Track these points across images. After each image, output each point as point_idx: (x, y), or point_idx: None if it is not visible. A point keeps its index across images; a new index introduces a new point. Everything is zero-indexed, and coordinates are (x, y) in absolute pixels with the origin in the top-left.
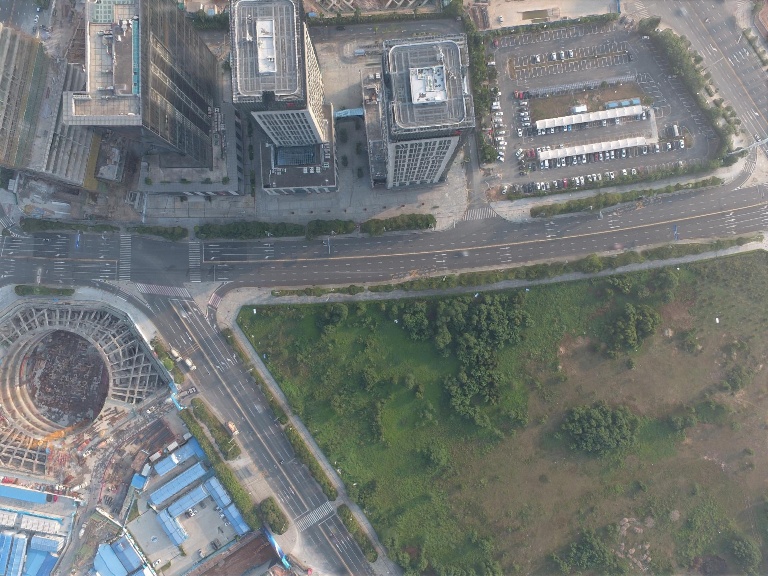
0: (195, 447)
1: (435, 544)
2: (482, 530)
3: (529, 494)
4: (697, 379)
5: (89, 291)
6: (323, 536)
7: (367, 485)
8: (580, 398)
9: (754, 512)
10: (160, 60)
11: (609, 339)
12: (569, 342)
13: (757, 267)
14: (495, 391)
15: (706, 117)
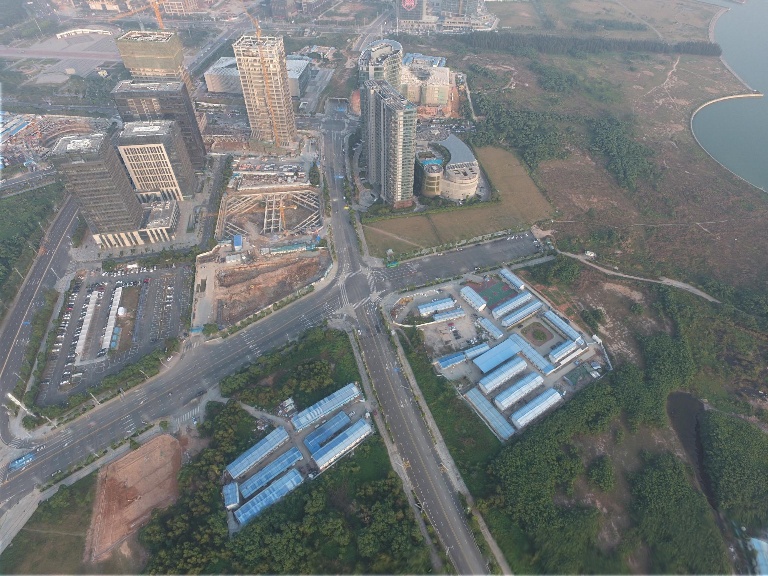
0: None
1: None
2: None
3: None
4: None
5: None
6: None
7: None
8: None
9: None
10: (154, 108)
11: None
12: None
13: None
14: None
15: None
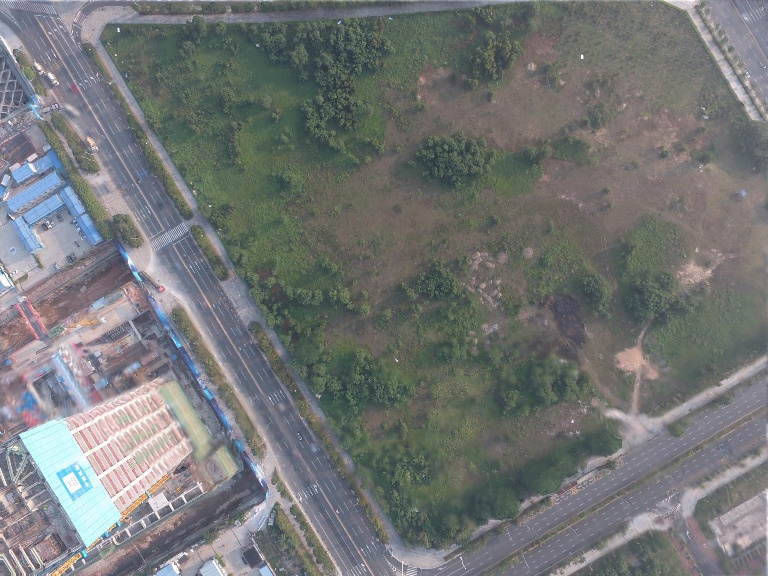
0: (53, 158)
1: (286, 269)
2: (334, 257)
3: (382, 224)
4: (558, 115)
5: None
6: (177, 256)
7: (222, 207)
8: (438, 129)
9: (610, 254)
10: None
11: (470, 70)
12: (430, 73)
13: (627, 4)
14: (351, 116)
15: None
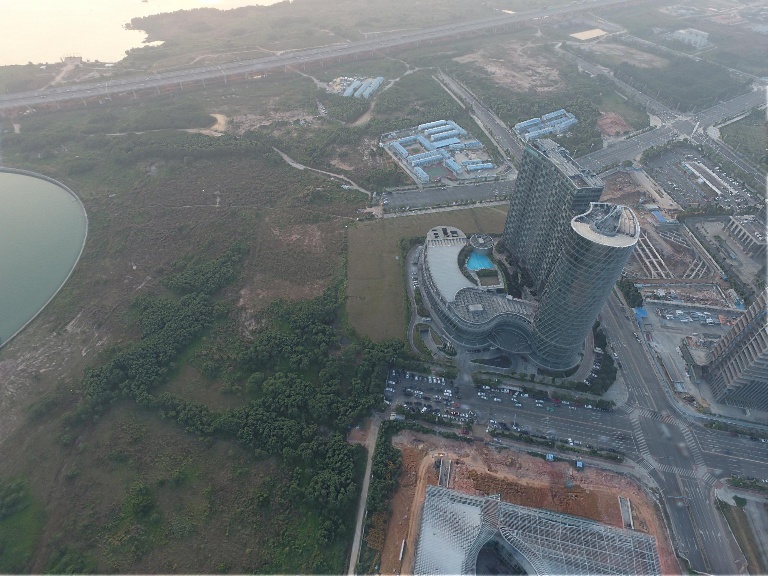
0: None
1: None
2: None
3: None
4: None
5: None
6: None
7: None
8: None
9: None
10: None
11: None
12: None
13: None
14: None
15: (673, 149)
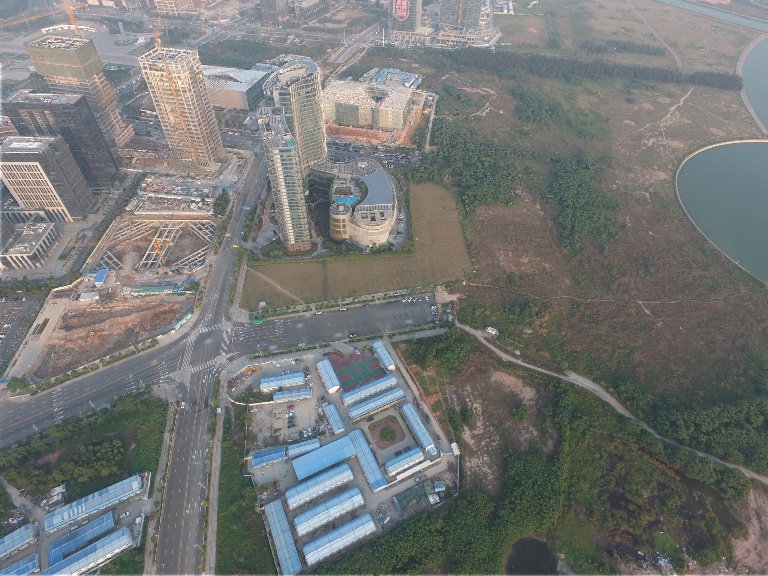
0: None
1: None
2: None
3: None
4: None
5: None
6: None
7: None
8: None
9: None
10: None
11: None
12: None
13: None
14: None
15: None
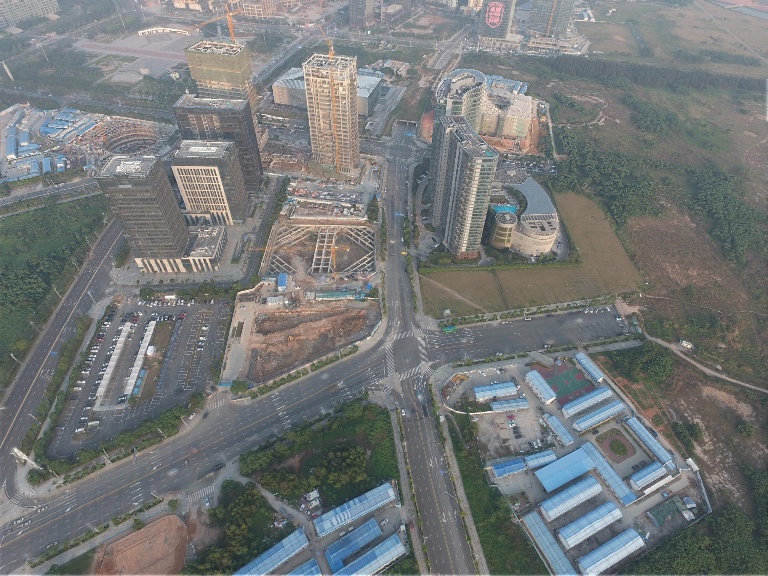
0: None
1: None
2: None
3: None
4: None
5: (167, 150)
6: None
7: None
8: None
9: None
10: (214, 126)
11: None
12: None
13: None
14: None
15: None
